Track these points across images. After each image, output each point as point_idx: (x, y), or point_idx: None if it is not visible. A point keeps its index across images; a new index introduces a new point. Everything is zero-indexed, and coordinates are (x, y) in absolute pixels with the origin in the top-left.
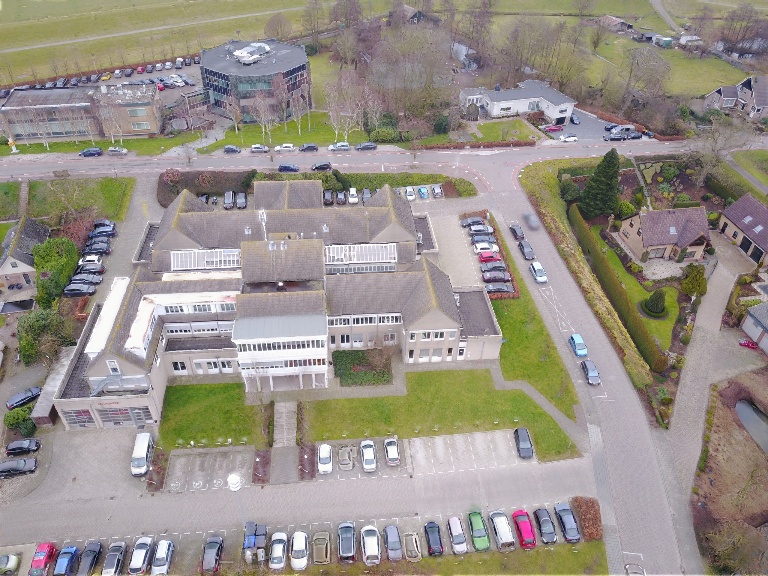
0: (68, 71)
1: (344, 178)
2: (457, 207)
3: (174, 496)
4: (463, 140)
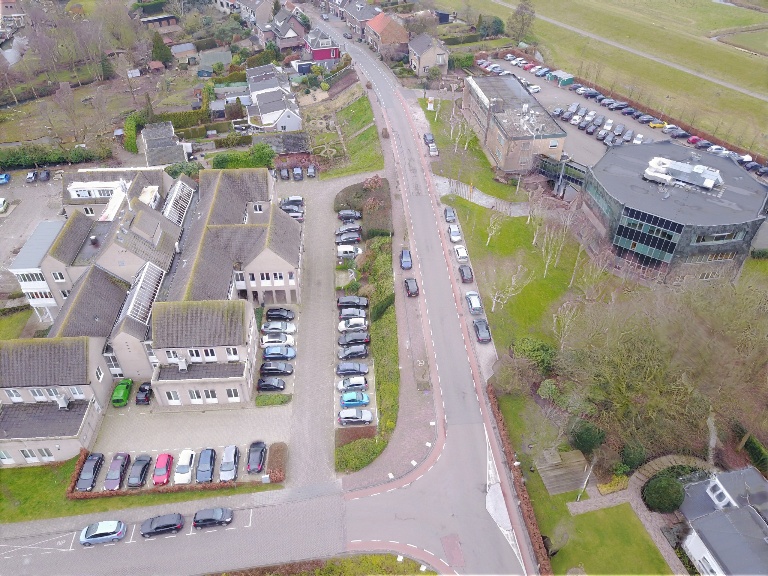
0: (639, 100)
1: (375, 306)
2: (310, 442)
3: (3, 260)
4: (545, 471)
